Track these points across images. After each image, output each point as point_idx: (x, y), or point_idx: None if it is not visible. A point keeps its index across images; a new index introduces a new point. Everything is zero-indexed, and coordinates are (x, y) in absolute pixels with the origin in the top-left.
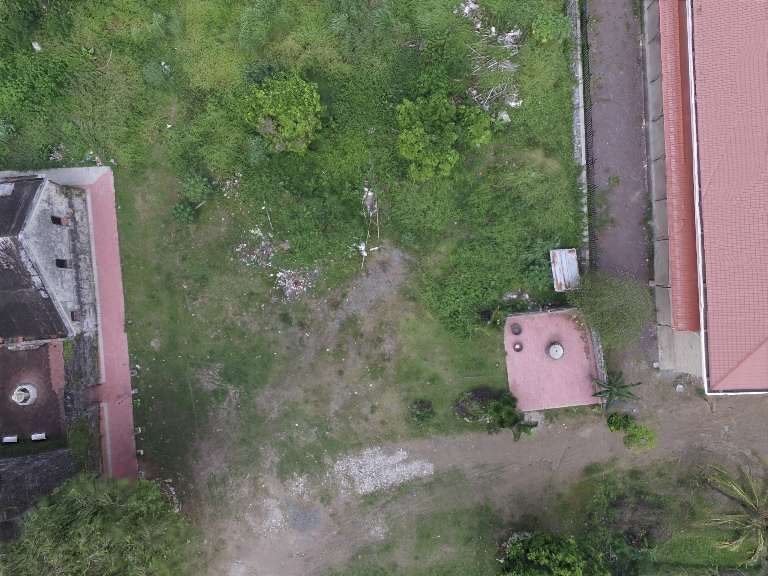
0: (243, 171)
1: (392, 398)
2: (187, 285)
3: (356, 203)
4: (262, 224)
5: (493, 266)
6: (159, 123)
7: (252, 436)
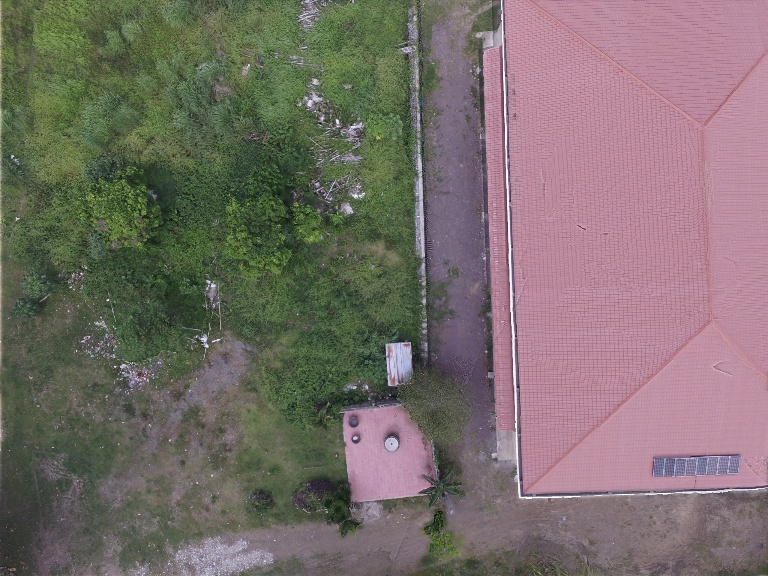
0: (88, 264)
1: (233, 488)
2: (33, 376)
3: (198, 296)
4: (106, 316)
5: (331, 359)
6: (7, 216)
7: (95, 525)
